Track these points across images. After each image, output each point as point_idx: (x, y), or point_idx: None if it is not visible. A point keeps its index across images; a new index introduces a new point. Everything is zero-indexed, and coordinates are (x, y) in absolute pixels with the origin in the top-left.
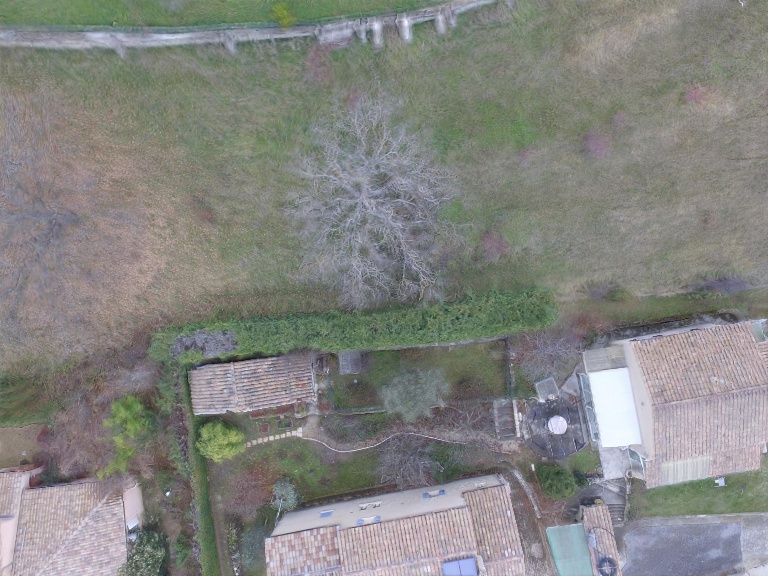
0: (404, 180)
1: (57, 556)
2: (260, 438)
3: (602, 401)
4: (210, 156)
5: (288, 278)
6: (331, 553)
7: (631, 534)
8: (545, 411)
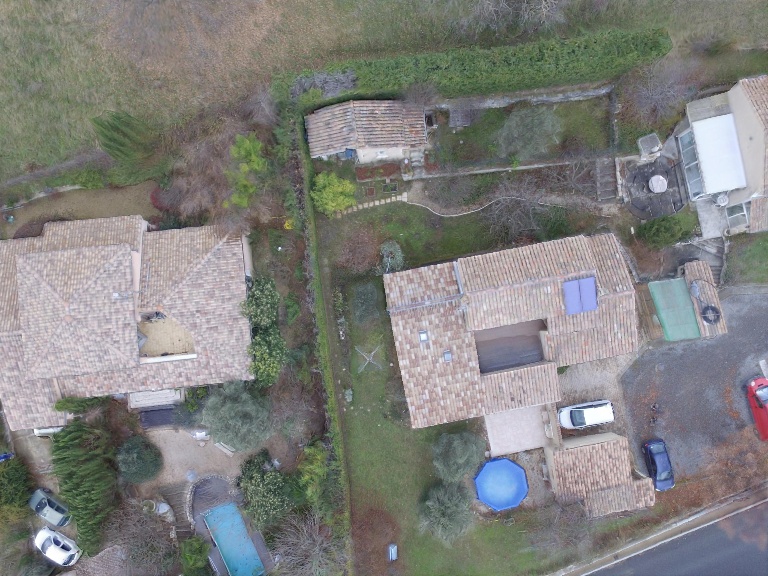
0: None
1: (182, 286)
2: (366, 203)
3: (707, 148)
4: None
5: (400, 31)
6: (450, 284)
7: (725, 302)
8: (644, 175)
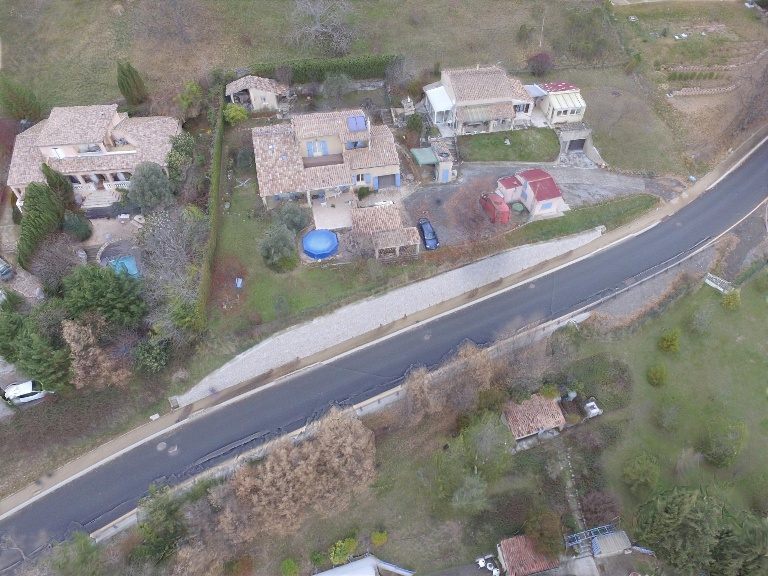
0: (334, 7)
1: (139, 126)
2: None
3: (433, 97)
4: (255, 21)
5: None
6: None
7: (464, 170)
8: None
